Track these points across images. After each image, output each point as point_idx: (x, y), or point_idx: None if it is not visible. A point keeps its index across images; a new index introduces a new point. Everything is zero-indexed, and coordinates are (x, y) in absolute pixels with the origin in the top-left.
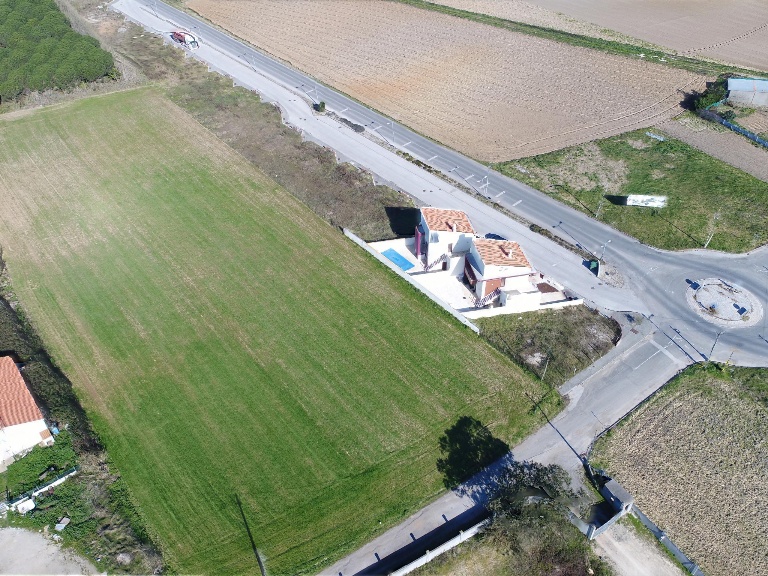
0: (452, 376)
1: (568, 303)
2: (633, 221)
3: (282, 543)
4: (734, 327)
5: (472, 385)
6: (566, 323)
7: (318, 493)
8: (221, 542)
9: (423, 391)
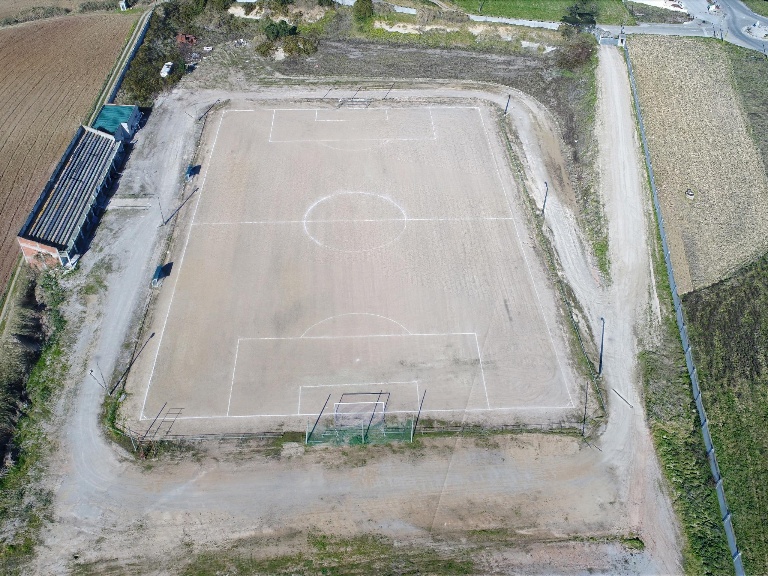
0: (597, 6)
1: (679, 9)
2: (760, 5)
3: (492, 8)
4: (754, 38)
5: (602, 9)
6: (670, 13)
7: (514, 5)
8: (473, 2)
9: (580, 4)
